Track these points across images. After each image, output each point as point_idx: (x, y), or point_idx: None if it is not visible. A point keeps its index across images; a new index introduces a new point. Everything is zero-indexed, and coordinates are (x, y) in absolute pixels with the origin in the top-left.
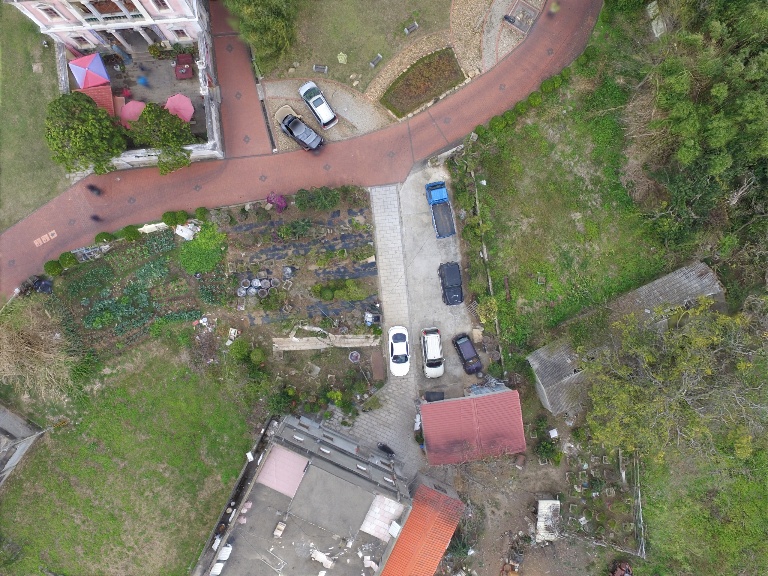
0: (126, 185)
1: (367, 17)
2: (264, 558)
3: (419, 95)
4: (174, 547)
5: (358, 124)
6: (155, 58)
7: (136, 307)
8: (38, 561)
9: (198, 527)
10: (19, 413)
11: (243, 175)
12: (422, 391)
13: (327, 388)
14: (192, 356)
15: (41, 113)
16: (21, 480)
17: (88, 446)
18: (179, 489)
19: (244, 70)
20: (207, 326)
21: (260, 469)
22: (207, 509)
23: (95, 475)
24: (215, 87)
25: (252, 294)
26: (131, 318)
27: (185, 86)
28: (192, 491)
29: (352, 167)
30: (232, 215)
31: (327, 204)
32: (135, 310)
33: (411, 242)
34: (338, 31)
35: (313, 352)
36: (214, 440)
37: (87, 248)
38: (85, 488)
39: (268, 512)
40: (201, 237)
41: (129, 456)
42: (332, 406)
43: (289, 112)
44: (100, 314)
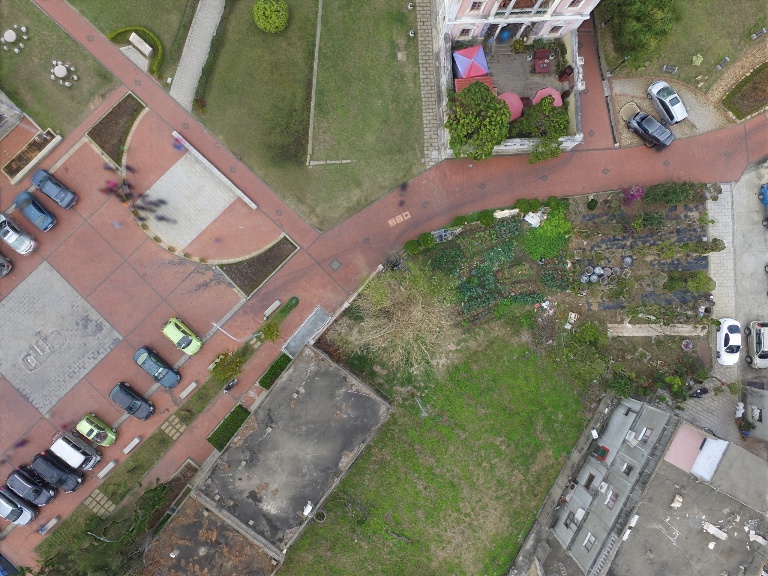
0: (478, 172)
1: (716, 21)
2: (660, 527)
3: (764, 98)
4: (507, 516)
5: (698, 123)
6: (513, 52)
7: (482, 288)
8: (383, 522)
9: (529, 498)
10: (370, 382)
11: (587, 167)
12: (744, 381)
13: (662, 373)
14: (534, 337)
15: (402, 99)
16: (370, 445)
17: (433, 417)
18: (514, 461)
19: (592, 67)
20: (549, 309)
21: (670, 444)
22: (539, 482)
23: (437, 444)
24: (565, 82)
25: (593, 281)
26: (477, 298)
27: (537, 80)
28: (525, 464)
29: (690, 164)
30: (577, 205)
31: (682, 199)
32: (482, 291)
33: (741, 239)
34: (688, 33)
35: (663, 338)
36: (549, 417)
37: (445, 230)
38: (428, 456)
39: (666, 485)
40: (547, 224)
41: (469, 428)
42: (661, 390)
43: (634, 109)
44: (450, 293)
